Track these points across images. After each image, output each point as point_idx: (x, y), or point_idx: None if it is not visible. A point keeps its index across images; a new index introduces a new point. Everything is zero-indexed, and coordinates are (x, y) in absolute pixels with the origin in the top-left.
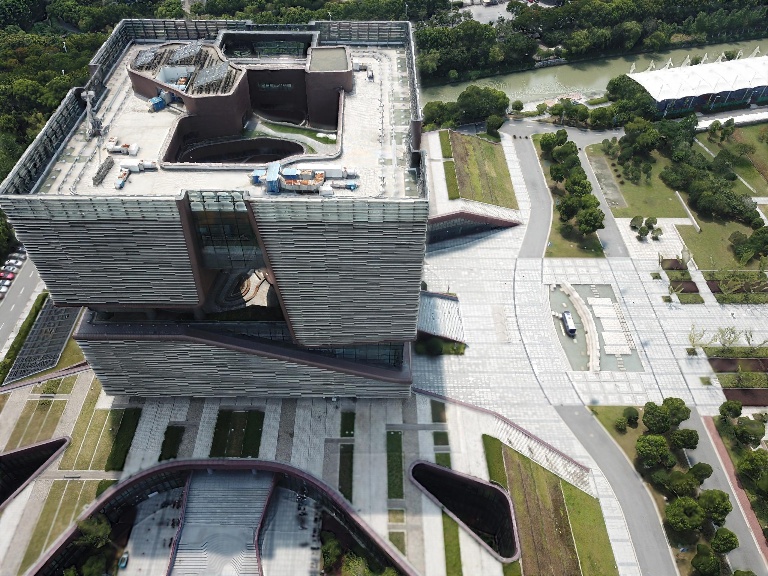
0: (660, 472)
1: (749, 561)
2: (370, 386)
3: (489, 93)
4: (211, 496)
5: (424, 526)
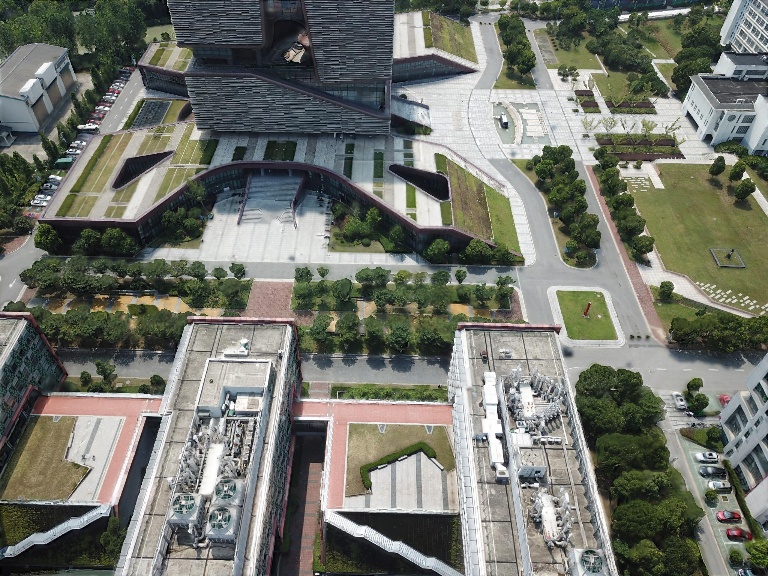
0: (549, 182)
1: (598, 225)
2: (364, 122)
3: None
4: (263, 186)
5: (395, 189)
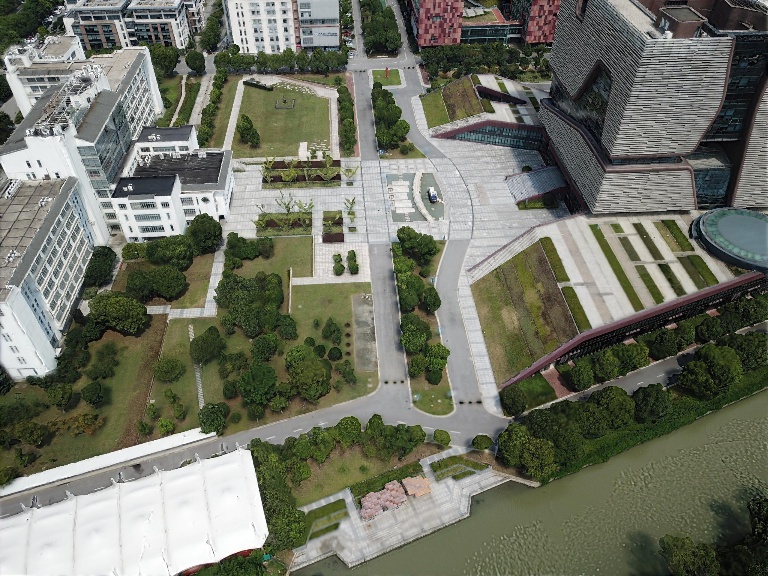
0: None
1: None
2: None
3: (539, 416)
4: None
5: None
